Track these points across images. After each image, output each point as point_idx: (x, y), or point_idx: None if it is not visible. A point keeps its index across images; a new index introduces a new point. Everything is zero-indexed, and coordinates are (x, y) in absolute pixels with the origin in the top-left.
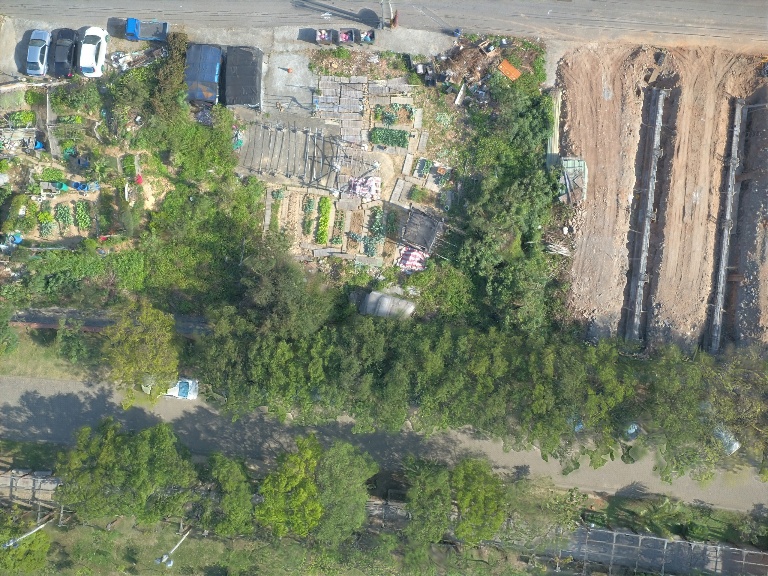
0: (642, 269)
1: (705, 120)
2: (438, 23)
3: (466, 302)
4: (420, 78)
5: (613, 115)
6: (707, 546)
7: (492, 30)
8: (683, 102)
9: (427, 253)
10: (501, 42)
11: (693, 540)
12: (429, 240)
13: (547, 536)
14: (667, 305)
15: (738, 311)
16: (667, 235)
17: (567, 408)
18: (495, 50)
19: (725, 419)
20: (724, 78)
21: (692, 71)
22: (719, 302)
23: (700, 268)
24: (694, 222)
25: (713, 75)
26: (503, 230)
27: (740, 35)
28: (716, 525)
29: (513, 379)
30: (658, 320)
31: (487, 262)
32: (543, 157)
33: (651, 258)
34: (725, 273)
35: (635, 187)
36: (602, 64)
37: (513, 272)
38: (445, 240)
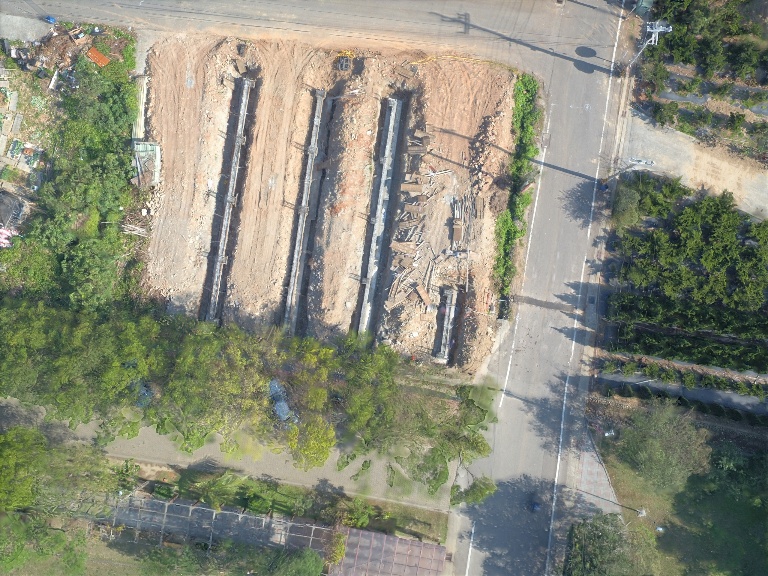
0: (220, 251)
1: (284, 110)
2: (36, 10)
3: (49, 279)
4: (16, 62)
5: (194, 103)
6: (273, 519)
7: (87, 18)
8: (264, 92)
9: (14, 231)
10: (93, 30)
11: (253, 512)
12: (6, 217)
13: (121, 506)
14: (240, 286)
15: (308, 294)
16: (243, 219)
17: (96, 379)
18: (85, 37)
19: (233, 392)
20: (303, 70)
21: (273, 63)
22: (291, 285)
23: (273, 251)
24: (269, 207)
25: (293, 67)
26: (78, 210)
27: (319, 30)
28: (282, 499)
29: (59, 351)
30: (230, 300)
31: (59, 240)
32: (129, 141)
33: (232, 241)
34: (303, 257)
35: (224, 173)
36: (188, 54)
37: (83, 250)
38: (33, 219)
